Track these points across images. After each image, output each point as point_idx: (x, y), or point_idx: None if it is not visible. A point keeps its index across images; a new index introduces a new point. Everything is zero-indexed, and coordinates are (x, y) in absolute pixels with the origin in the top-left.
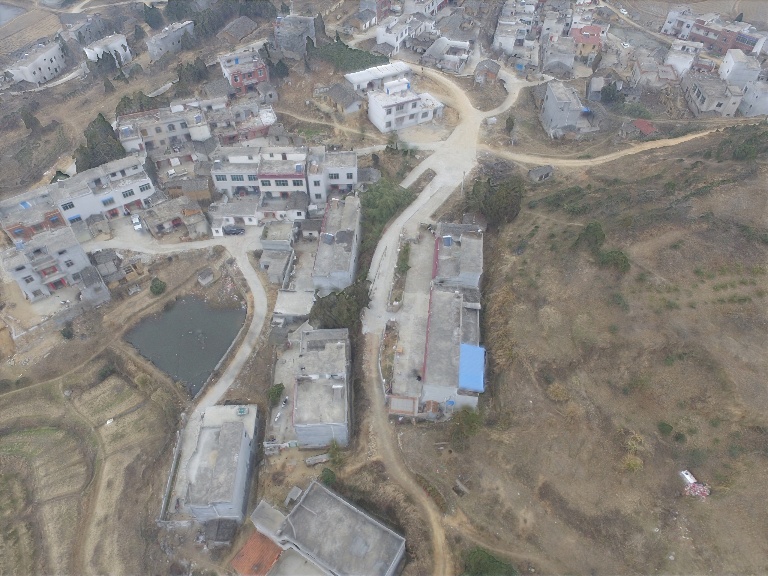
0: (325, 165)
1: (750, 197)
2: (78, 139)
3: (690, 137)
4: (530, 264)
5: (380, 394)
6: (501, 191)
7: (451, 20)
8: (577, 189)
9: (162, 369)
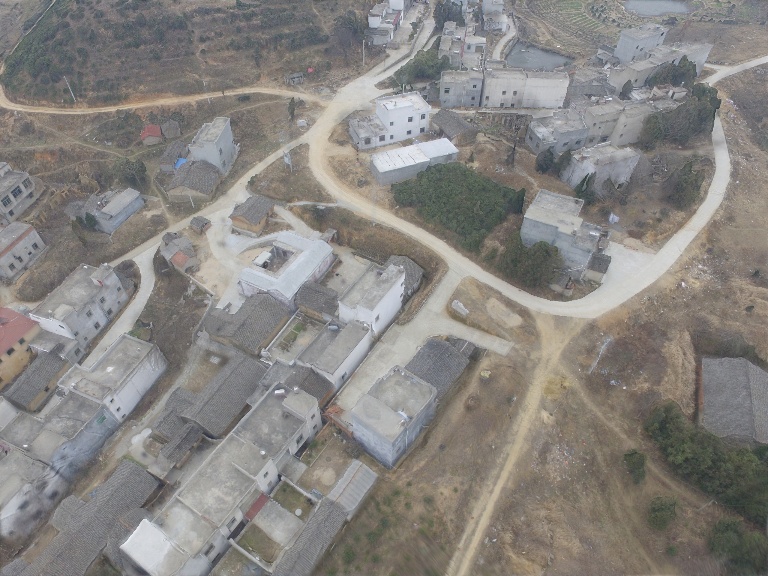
0: (468, 77)
1: (218, 2)
2: (761, 151)
3: (138, 106)
4: (351, 4)
5: (430, 5)
6: (350, 18)
7: (222, 384)
8: (292, 38)
9: (543, 53)
